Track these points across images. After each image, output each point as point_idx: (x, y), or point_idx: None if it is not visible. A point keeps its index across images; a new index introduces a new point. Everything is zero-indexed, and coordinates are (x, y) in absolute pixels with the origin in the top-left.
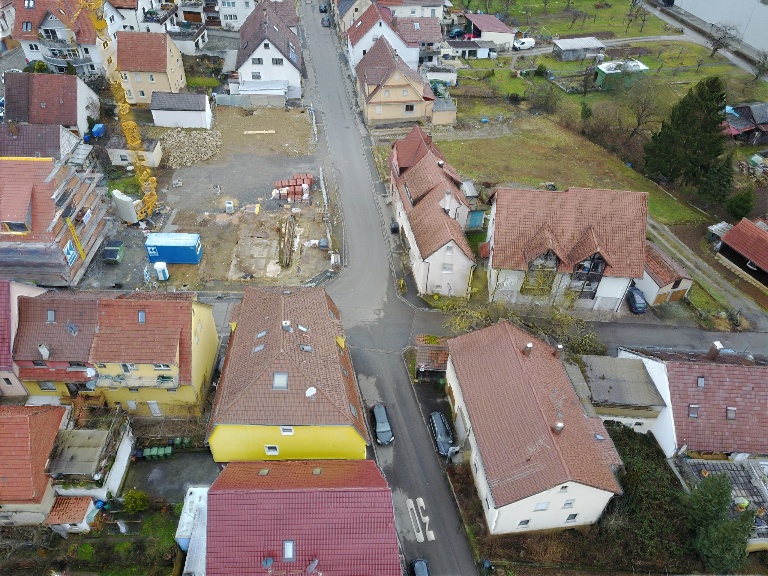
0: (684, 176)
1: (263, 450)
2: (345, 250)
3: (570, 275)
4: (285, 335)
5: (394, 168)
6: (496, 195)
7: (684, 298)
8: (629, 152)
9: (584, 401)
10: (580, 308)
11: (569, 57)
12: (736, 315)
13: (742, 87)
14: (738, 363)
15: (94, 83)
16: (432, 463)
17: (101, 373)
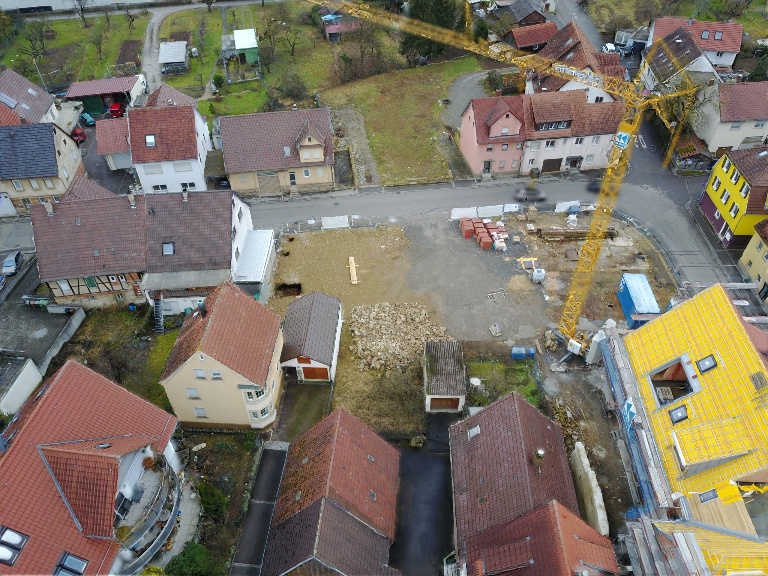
0: None
1: None
2: None
3: None
4: None
5: (502, 137)
6: None
7: None
8: None
9: None
10: None
11: None
12: None
13: (274, 11)
14: None
15: None
16: None
17: None
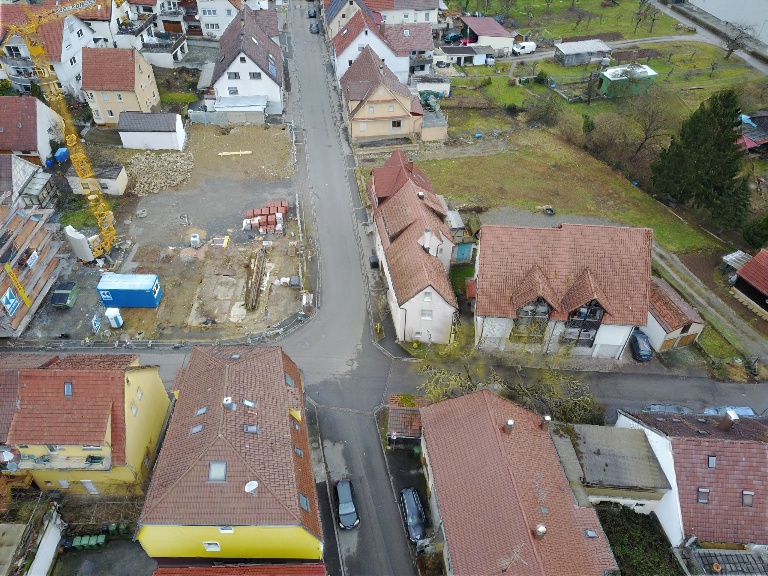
0: (695, 198)
1: (202, 546)
2: (319, 289)
3: (564, 322)
4: (226, 414)
5: (373, 197)
6: None
7: (695, 343)
8: (636, 168)
9: (575, 485)
10: (577, 356)
11: (572, 62)
12: (754, 363)
13: (760, 92)
14: (756, 438)
15: (61, 102)
16: (401, 551)
17: (24, 453)
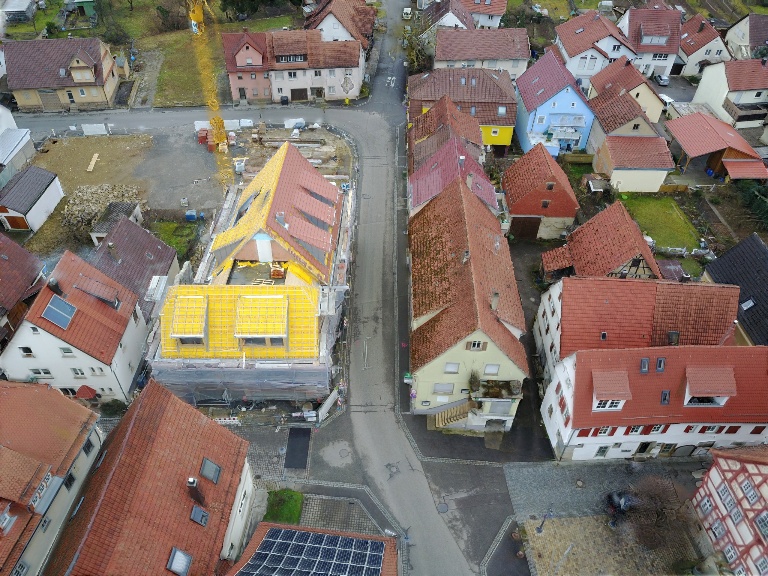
0: (260, 3)
1: None
2: None
3: None
4: None
5: (248, 67)
6: (325, 19)
7: None
8: None
9: None
10: None
11: (29, 15)
12: (378, 22)
13: None
14: (447, 0)
15: None
16: None
17: None
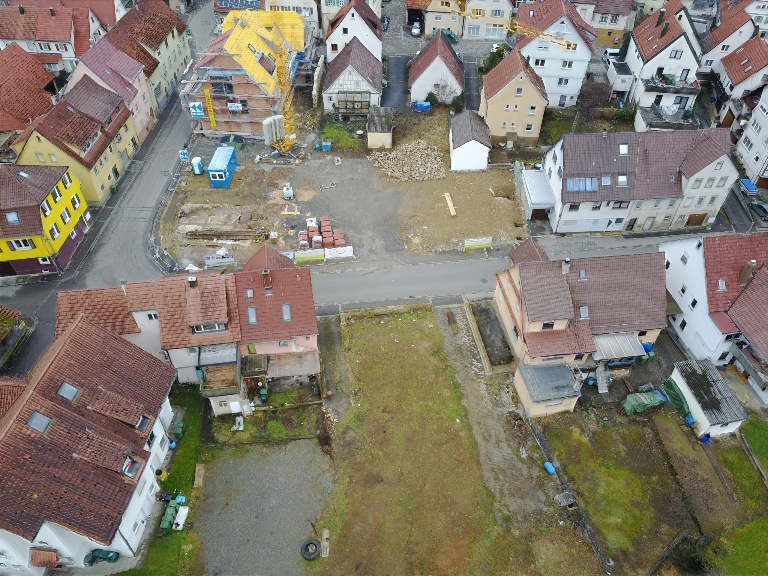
0: None
1: None
2: None
3: None
4: None
5: None
6: None
7: None
8: None
9: None
10: None
11: None
12: None
13: None
14: None
15: None
16: None
17: None
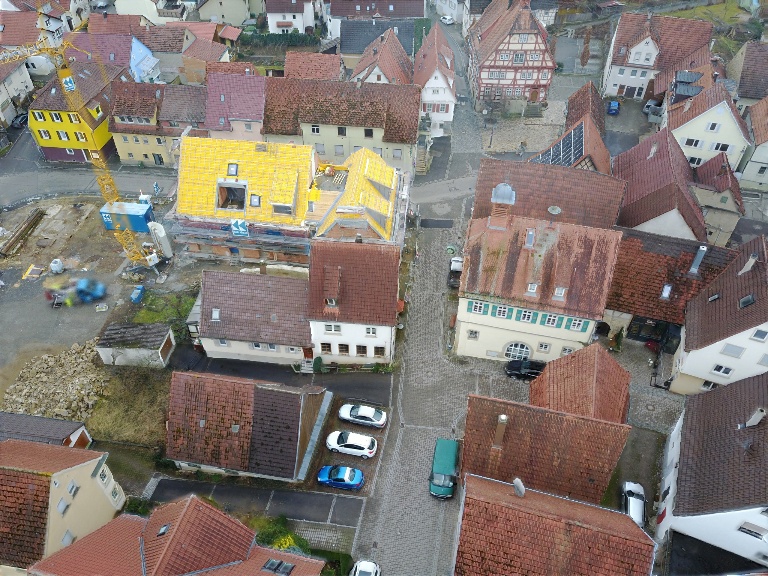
0: None
1: None
2: None
3: None
4: None
5: None
6: None
7: None
8: None
9: None
10: None
11: None
12: None
13: None
14: None
15: None
16: None
17: None
